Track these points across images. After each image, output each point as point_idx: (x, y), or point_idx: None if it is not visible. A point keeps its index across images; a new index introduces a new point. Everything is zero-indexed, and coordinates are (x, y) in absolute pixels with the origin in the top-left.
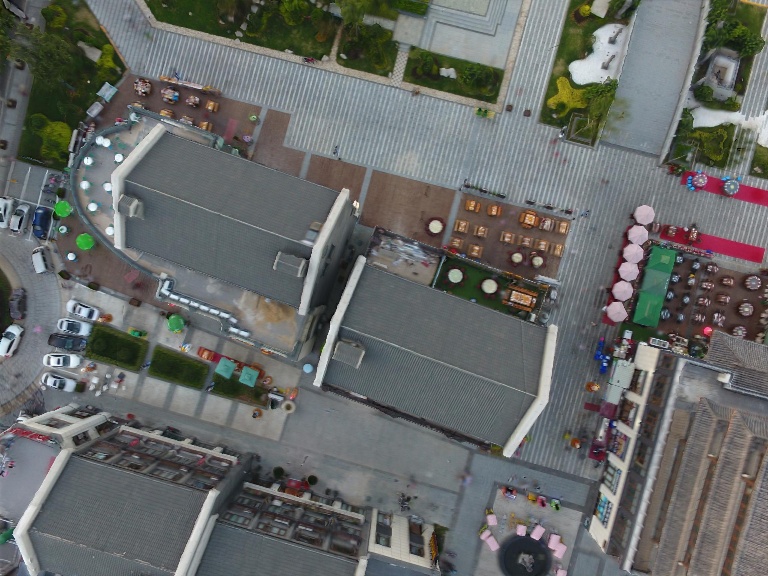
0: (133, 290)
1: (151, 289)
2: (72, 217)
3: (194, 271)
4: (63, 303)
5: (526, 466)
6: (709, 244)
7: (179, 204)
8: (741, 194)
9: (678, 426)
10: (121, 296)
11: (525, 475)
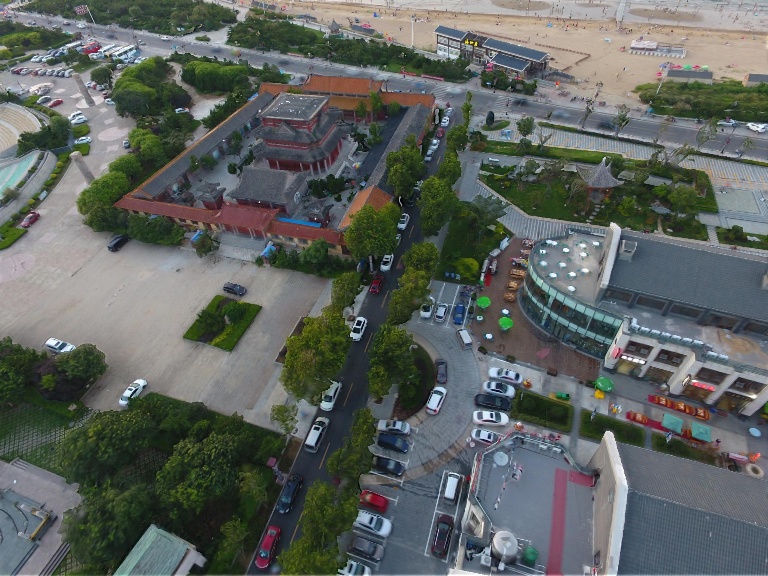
0: (547, 364)
1: (563, 363)
2: (483, 312)
3: (650, 316)
4: (481, 372)
5: None
6: None
7: (666, 247)
8: None
9: None
10: (536, 368)
11: None
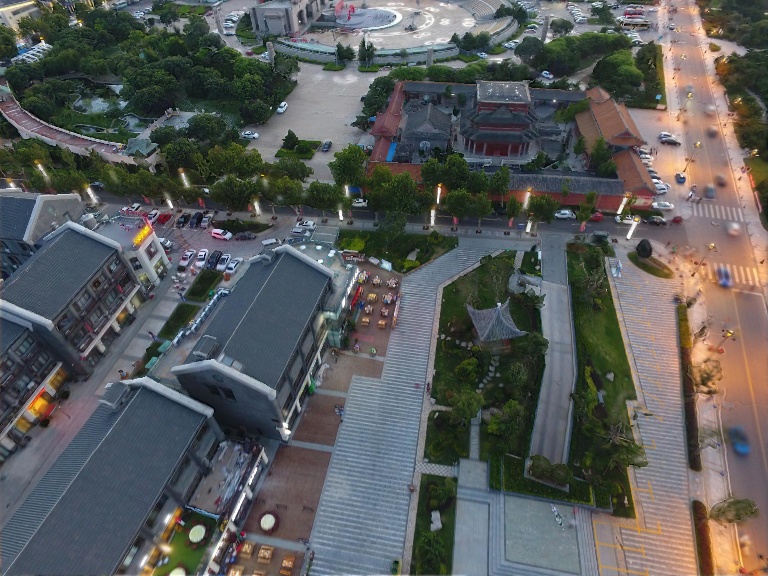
0: None
1: None
2: None
3: None
4: (243, 256)
5: None
6: None
7: None
8: None
9: None
10: None
11: None
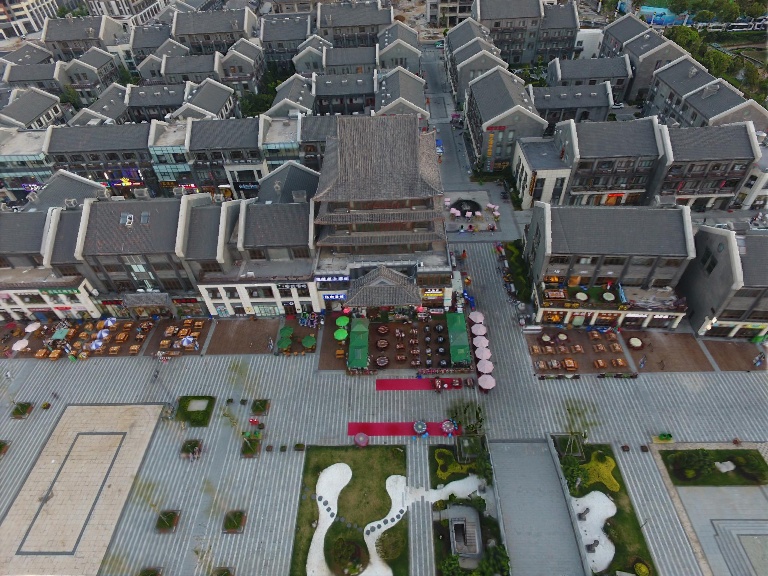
0: None
1: None
2: None
3: None
4: None
5: (487, 241)
6: (421, 383)
7: None
8: (407, 427)
9: (437, 244)
10: None
11: (485, 238)
